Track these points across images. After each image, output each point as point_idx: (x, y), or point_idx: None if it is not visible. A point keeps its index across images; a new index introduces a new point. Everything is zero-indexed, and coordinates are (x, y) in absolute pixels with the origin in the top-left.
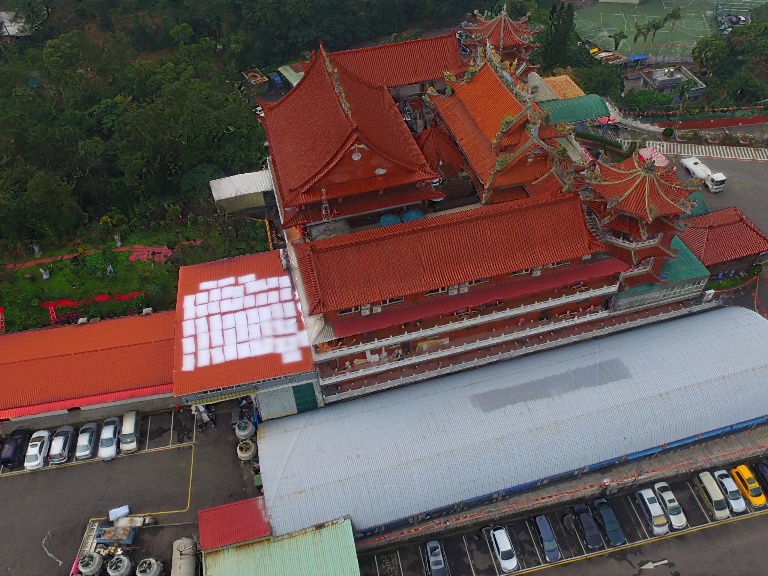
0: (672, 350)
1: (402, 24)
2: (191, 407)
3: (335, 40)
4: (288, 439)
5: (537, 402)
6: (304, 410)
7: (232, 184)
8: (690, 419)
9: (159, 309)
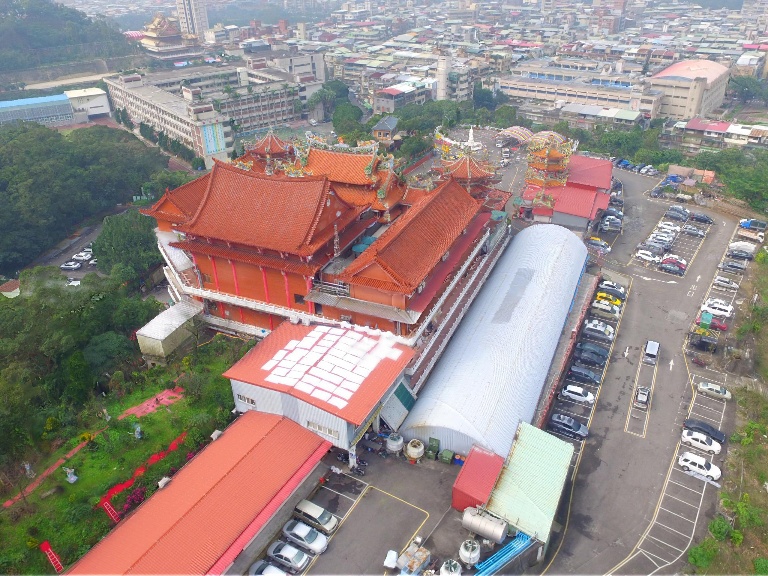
0: (532, 252)
1: (69, 228)
2: (333, 471)
3: (23, 255)
4: (442, 408)
5: (521, 303)
6: (411, 407)
7: (161, 324)
8: (571, 277)
9: (211, 438)
